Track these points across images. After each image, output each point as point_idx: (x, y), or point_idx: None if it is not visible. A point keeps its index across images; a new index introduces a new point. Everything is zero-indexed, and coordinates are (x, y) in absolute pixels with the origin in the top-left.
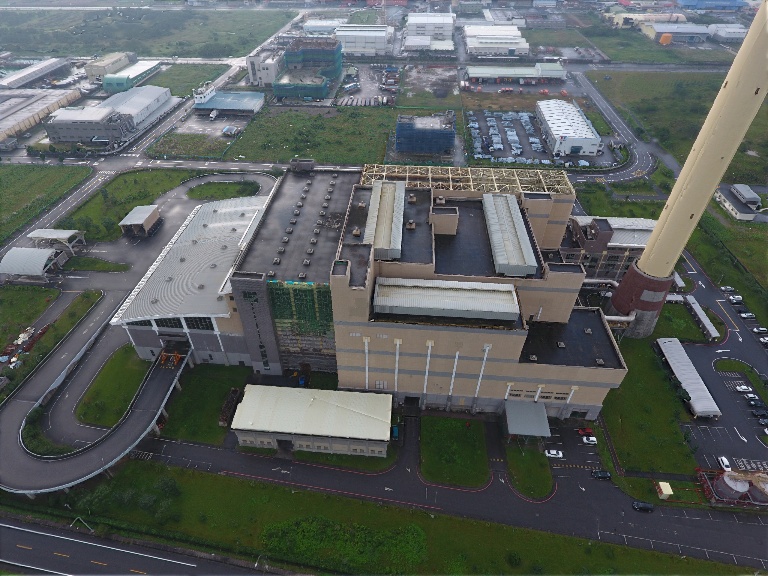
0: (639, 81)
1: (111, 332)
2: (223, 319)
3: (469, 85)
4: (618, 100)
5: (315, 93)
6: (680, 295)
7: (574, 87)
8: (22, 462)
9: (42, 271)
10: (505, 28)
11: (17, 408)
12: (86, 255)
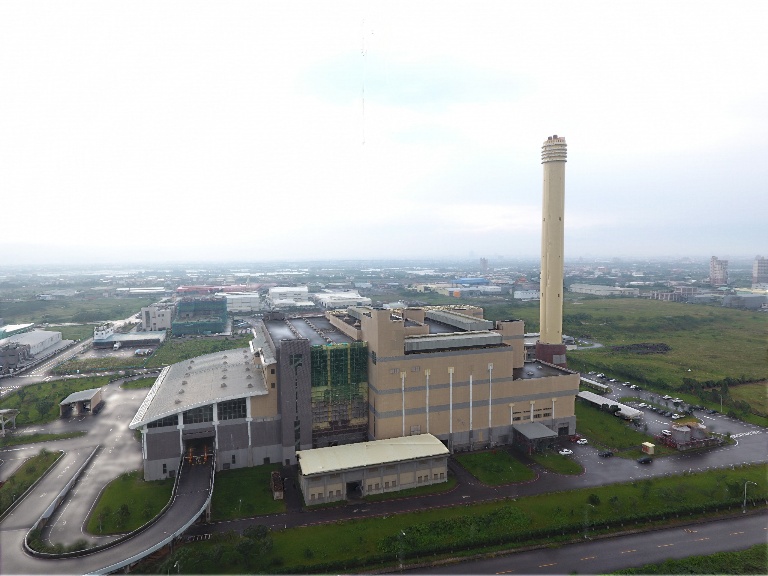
0: None
1: (94, 473)
2: (259, 399)
3: None
4: None
5: (214, 328)
6: None
7: None
8: (48, 565)
9: None
10: (346, 294)
11: (5, 536)
12: (20, 435)
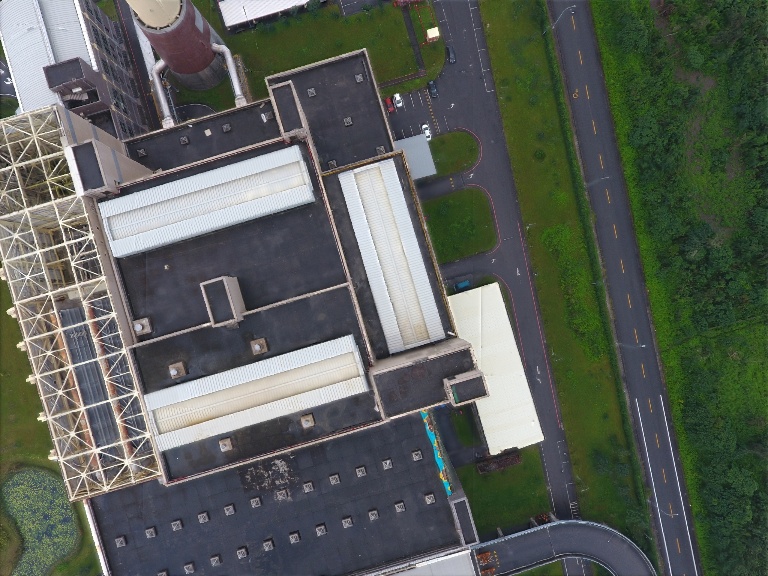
0: None
1: None
2: None
3: None
4: None
5: None
6: None
7: None
8: None
9: None
10: None
11: None
12: None
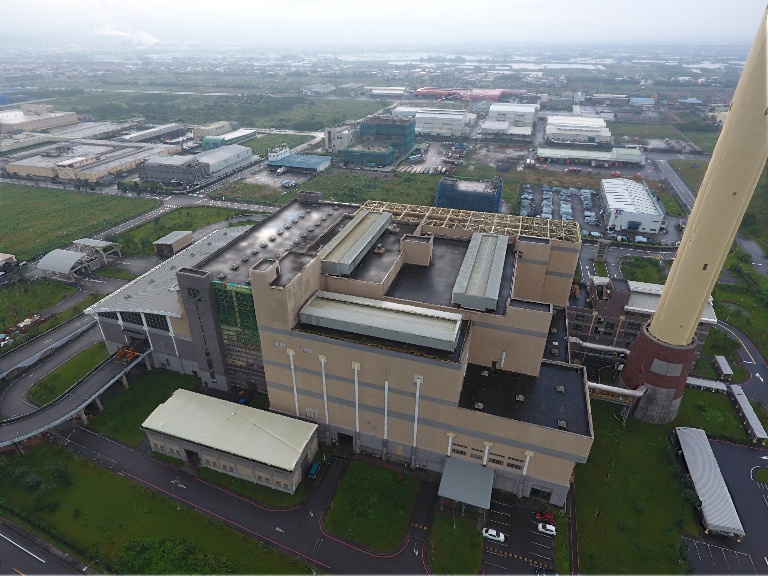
0: None
1: (99, 328)
2: (176, 320)
3: (534, 163)
4: None
5: (379, 160)
6: (723, 383)
7: (652, 172)
8: None
9: (70, 270)
10: (590, 119)
11: None
12: (116, 265)
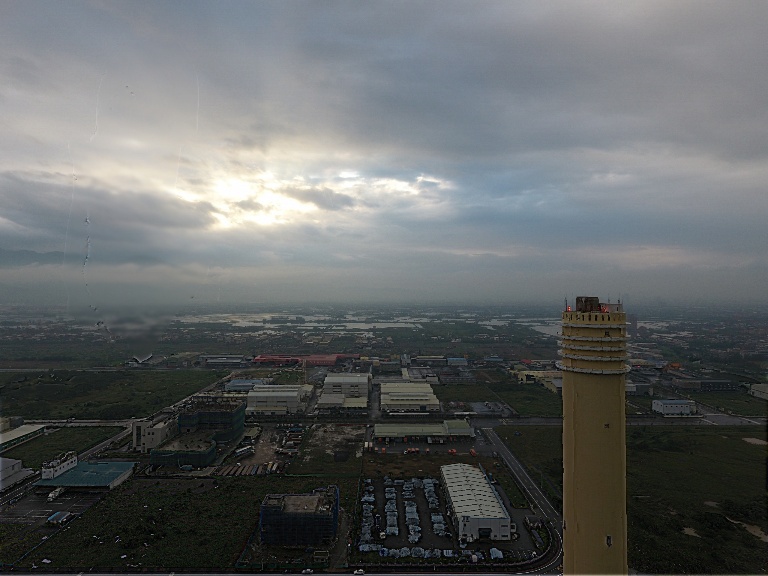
0: (549, 437)
1: None
2: None
3: (373, 446)
4: (530, 460)
5: (197, 460)
6: None
7: (484, 445)
8: None
9: None
10: (418, 385)
11: None
12: None
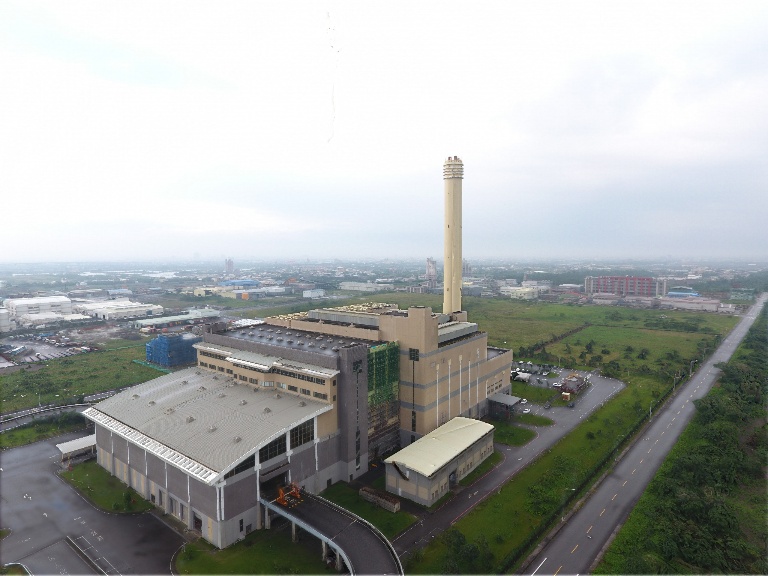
0: None
1: (125, 568)
2: (324, 416)
3: None
4: None
5: None
6: None
7: None
8: None
9: None
10: (119, 302)
11: None
12: None
